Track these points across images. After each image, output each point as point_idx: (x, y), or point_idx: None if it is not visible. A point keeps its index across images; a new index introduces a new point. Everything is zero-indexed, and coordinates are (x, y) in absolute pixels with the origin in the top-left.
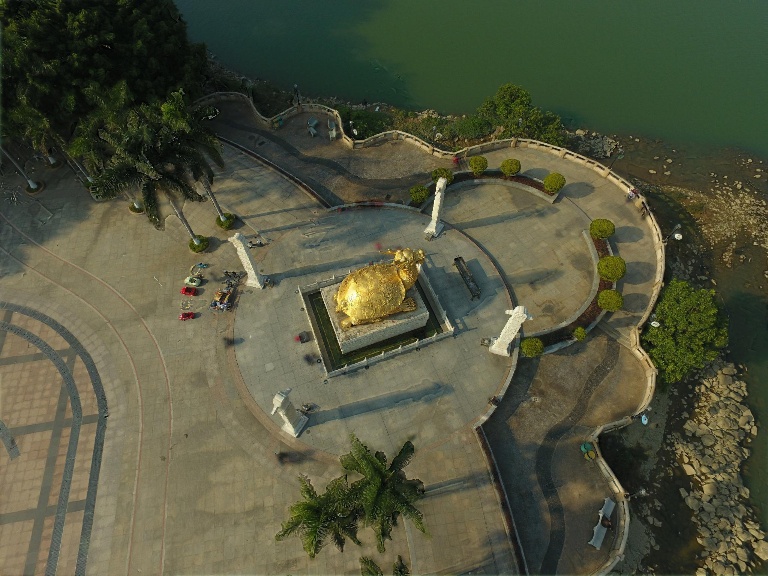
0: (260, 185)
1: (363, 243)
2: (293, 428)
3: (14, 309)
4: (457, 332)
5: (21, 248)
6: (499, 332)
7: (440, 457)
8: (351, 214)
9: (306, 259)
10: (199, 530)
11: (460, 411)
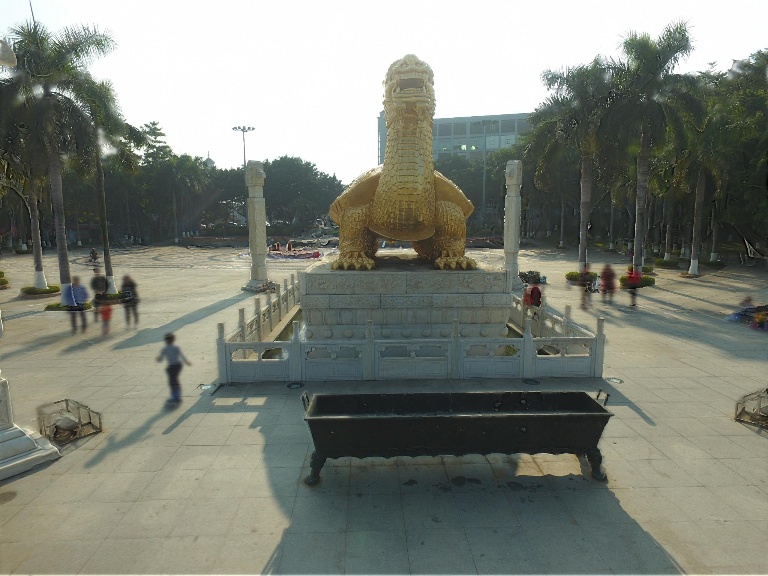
0: (760, 293)
1: (638, 333)
2: (252, 276)
3: (492, 261)
4: (216, 390)
5: (561, 261)
6: (34, 492)
7: (4, 332)
8: (759, 333)
9: (563, 302)
10: (224, 279)
11: (15, 357)
